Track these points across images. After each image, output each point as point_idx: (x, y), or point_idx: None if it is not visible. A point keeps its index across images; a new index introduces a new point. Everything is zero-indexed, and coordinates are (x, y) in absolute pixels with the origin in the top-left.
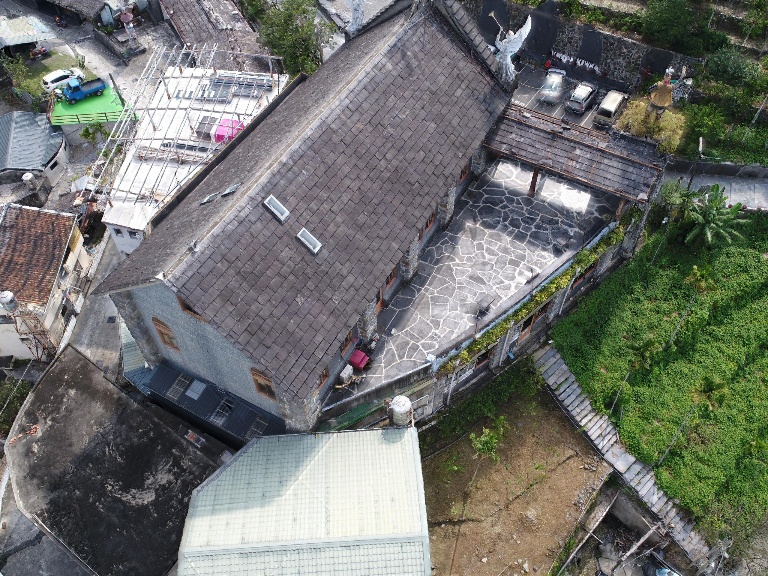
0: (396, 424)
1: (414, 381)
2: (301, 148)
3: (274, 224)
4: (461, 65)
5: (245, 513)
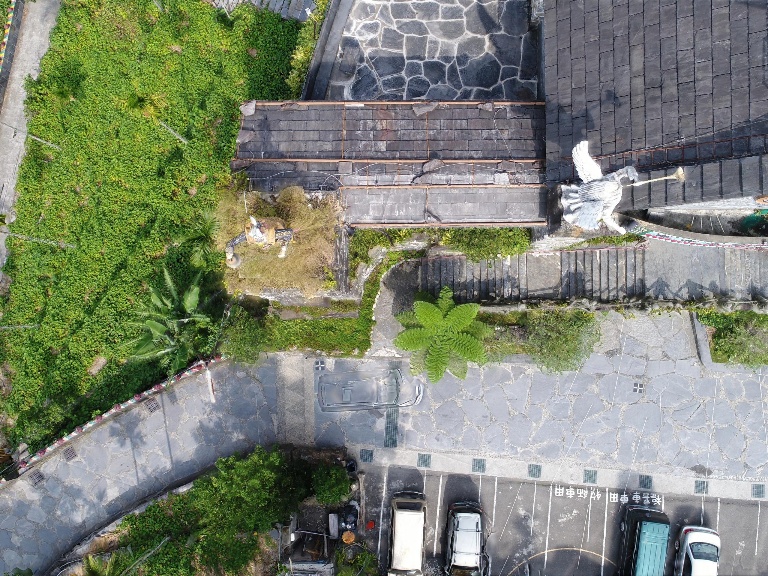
0: None
1: None
2: None
3: None
4: (672, 115)
5: None
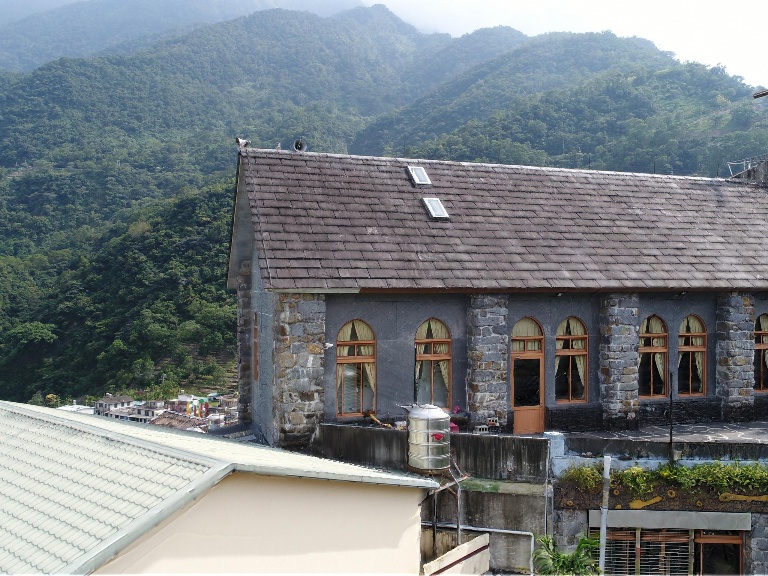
0: (409, 465)
1: (509, 477)
2: (494, 169)
3: (404, 183)
4: None
5: (88, 418)
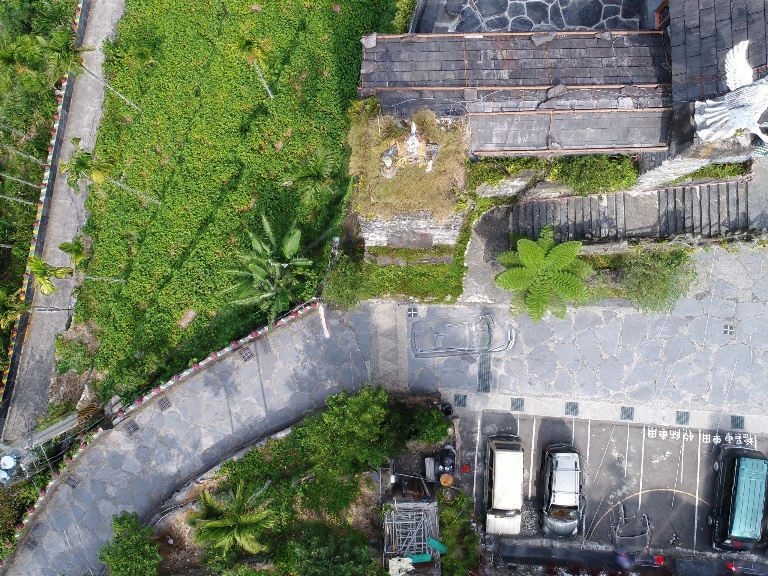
0: None
1: None
2: None
3: None
4: None
5: None
